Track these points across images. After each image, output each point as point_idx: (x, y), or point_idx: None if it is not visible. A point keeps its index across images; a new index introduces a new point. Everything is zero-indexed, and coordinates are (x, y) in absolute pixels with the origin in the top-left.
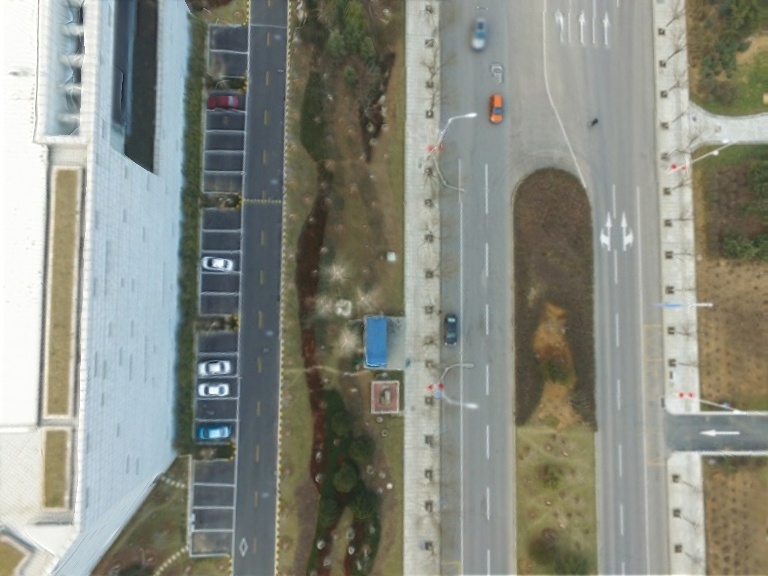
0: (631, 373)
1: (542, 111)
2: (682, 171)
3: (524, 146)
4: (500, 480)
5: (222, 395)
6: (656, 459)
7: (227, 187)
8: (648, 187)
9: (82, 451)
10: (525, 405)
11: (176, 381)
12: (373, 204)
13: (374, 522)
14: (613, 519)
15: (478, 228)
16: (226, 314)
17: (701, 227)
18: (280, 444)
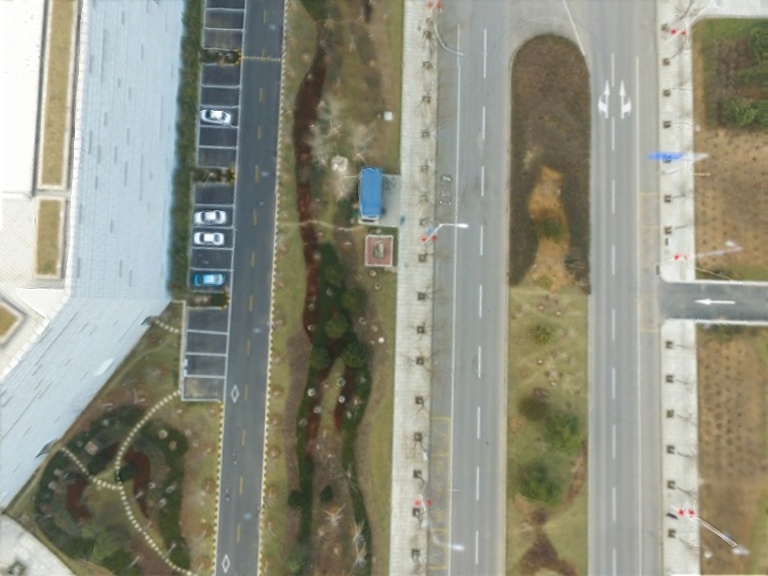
0: (626, 239)
1: None
2: (682, 36)
3: (523, 13)
4: (492, 339)
5: (217, 244)
6: (650, 325)
7: (227, 44)
8: (647, 57)
9: (74, 217)
10: (519, 265)
11: (172, 225)
12: (371, 63)
13: (365, 374)
14: (605, 382)
15: (476, 92)
16: (223, 167)
17: (700, 98)
18: (273, 295)
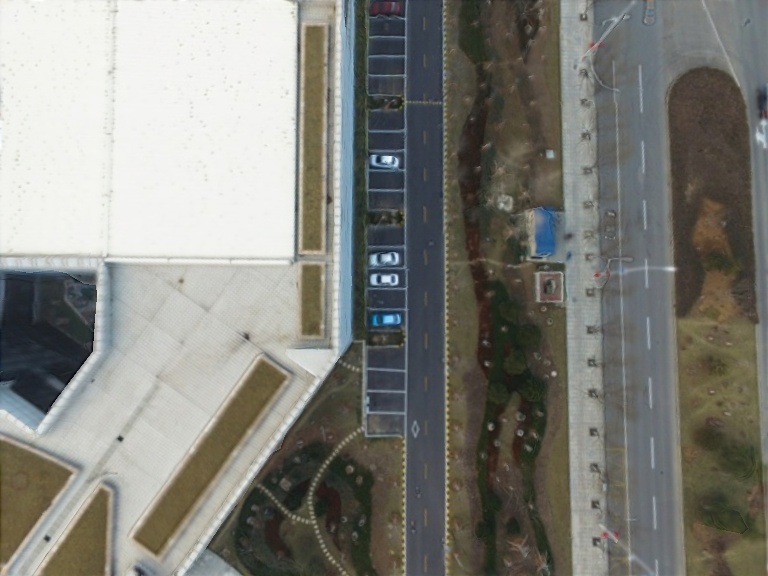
0: None
1: (694, 12)
2: None
3: (677, 47)
4: (662, 370)
5: (392, 285)
6: None
7: (390, 90)
8: None
9: (338, 281)
10: (686, 297)
11: (353, 268)
12: (532, 103)
13: (540, 407)
14: None
15: (633, 127)
16: (393, 209)
17: None
18: (447, 332)
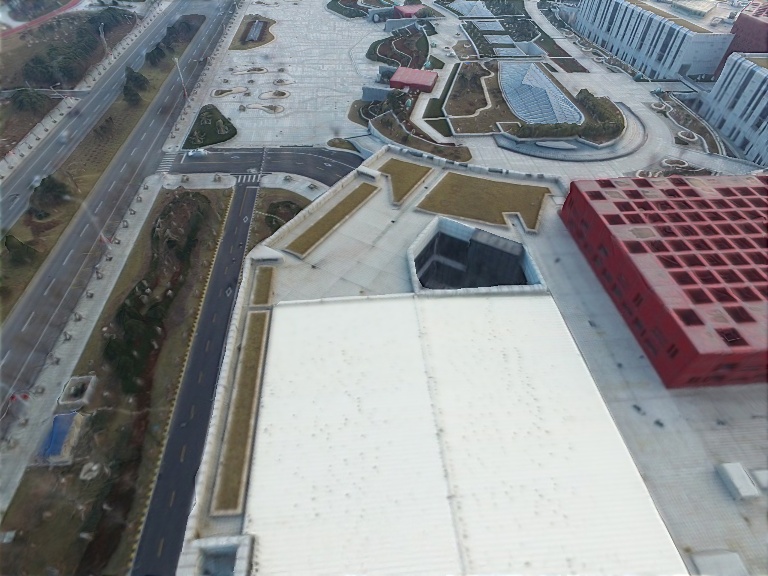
0: None
1: None
2: None
3: None
4: (8, 337)
5: None
6: None
7: None
8: None
9: None
10: None
11: None
12: None
13: None
14: None
15: None
16: None
17: None
18: (187, 353)
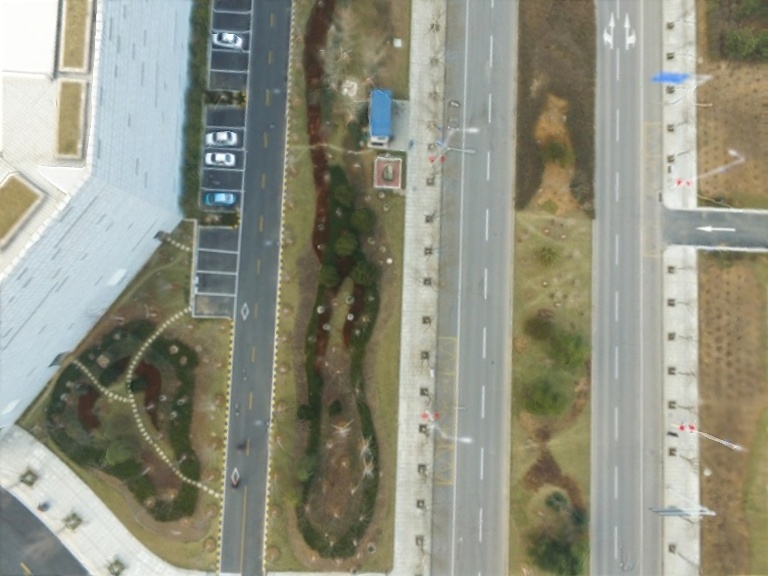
0: (630, 167)
1: None
2: None
3: None
4: (498, 261)
5: (228, 165)
6: (652, 251)
7: None
8: None
9: (96, 97)
10: (525, 189)
11: (184, 143)
12: None
13: (373, 293)
14: (608, 305)
15: (483, 21)
16: (234, 90)
17: (703, 30)
18: (283, 216)
